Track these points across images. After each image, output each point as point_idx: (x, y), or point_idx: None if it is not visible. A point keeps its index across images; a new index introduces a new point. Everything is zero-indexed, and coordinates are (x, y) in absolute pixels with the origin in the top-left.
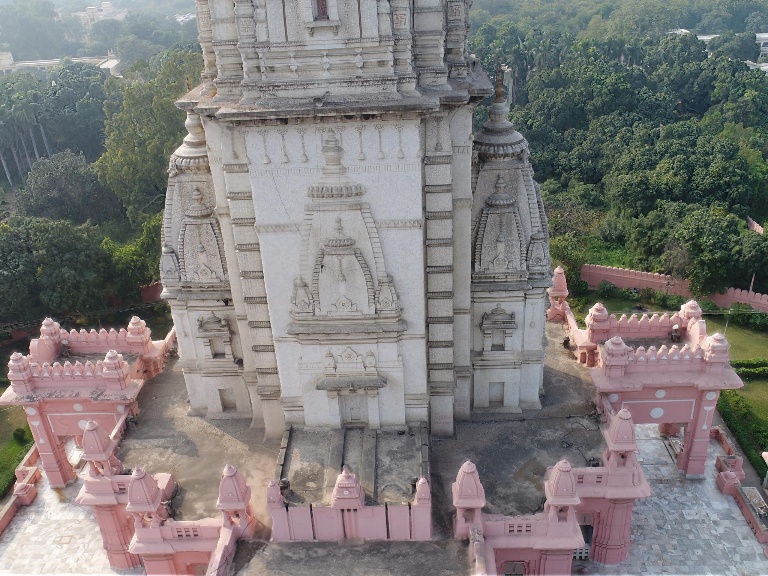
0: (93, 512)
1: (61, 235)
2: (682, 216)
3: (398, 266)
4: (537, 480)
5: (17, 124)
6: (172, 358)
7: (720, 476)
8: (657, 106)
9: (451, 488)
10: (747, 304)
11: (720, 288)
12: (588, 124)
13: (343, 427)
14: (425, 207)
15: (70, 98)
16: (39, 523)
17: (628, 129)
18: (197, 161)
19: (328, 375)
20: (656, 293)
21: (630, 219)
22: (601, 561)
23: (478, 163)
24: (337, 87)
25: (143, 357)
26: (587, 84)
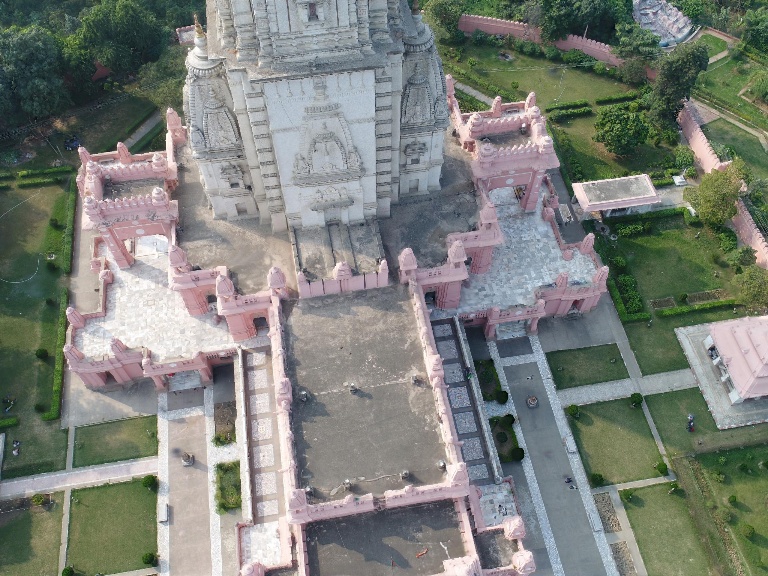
0: (159, 282)
1: (22, 49)
2: None
3: (360, 141)
4: (442, 241)
5: None
6: (180, 171)
7: (544, 211)
8: None
9: (394, 253)
10: (580, 51)
11: (563, 36)
12: None
13: (326, 225)
14: (375, 105)
15: None
16: (127, 294)
17: None
18: (210, 72)
19: (318, 202)
20: (516, 42)
21: None
22: (476, 273)
23: None
24: (323, 54)
25: (167, 180)
26: None
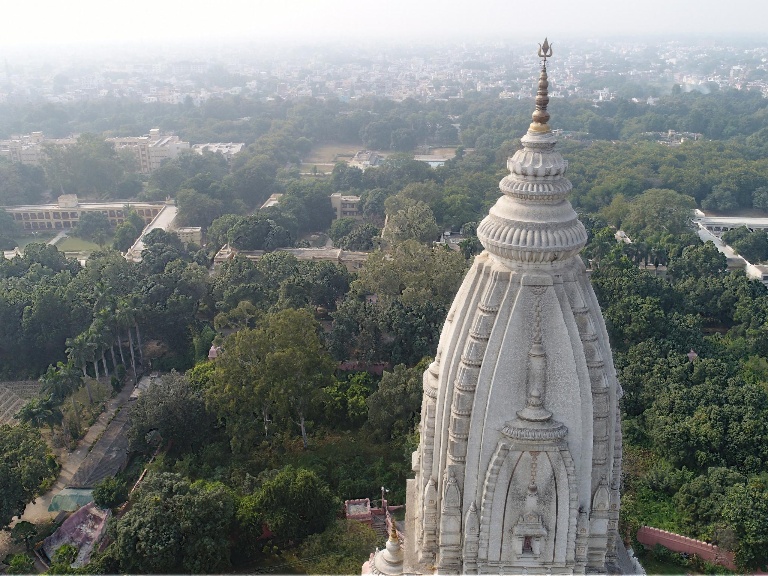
0: None
1: (204, 507)
2: (724, 484)
3: None
4: None
5: (119, 326)
6: None
7: None
8: (688, 333)
9: None
10: None
11: (762, 567)
12: (626, 345)
13: None
14: None
15: (161, 293)
16: None
17: (665, 361)
18: None
19: None
20: (705, 564)
21: (673, 465)
22: None
23: None
24: None
25: None
26: (625, 308)
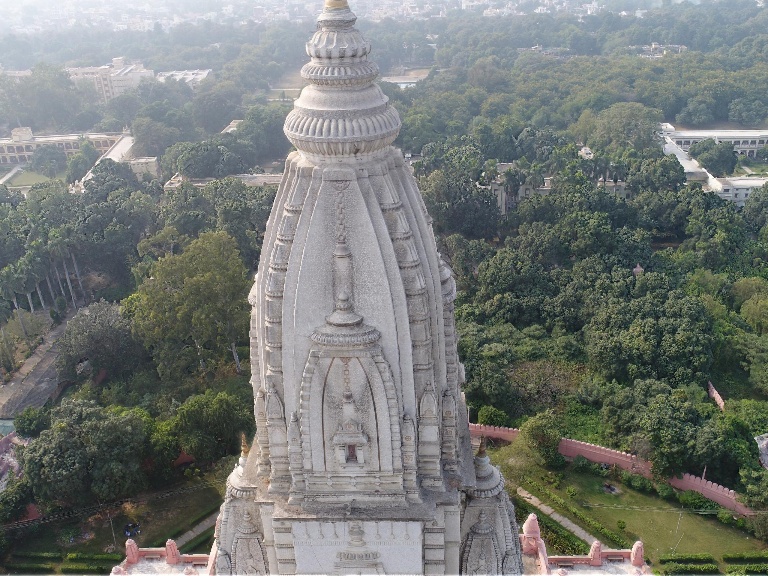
0: None
1: (110, 432)
2: (648, 395)
3: None
4: None
5: (52, 257)
6: None
7: None
8: (635, 247)
9: None
10: (699, 493)
11: (677, 474)
12: (572, 262)
13: None
14: (424, 557)
15: (98, 223)
16: None
17: (607, 276)
18: (248, 494)
19: None
20: (623, 474)
21: (605, 379)
22: None
23: (465, 501)
24: (361, 497)
25: None
26: (572, 224)
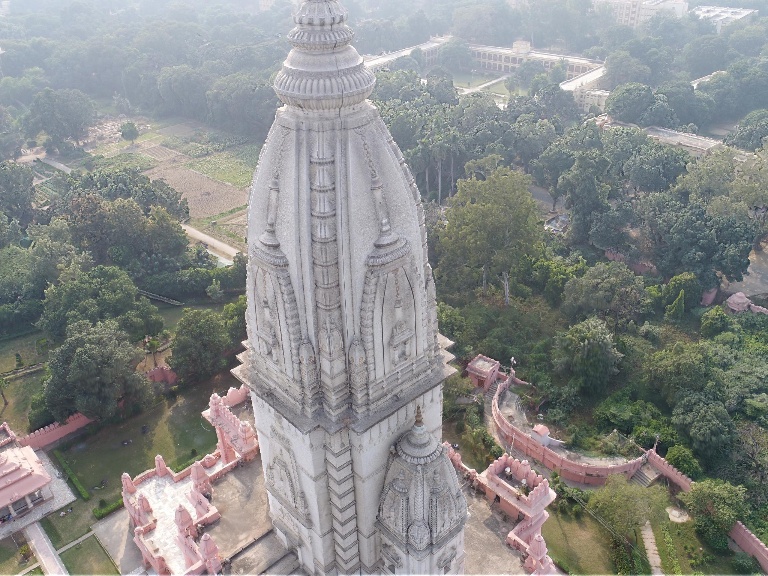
0: None
1: None
2: None
3: None
4: None
5: (433, 156)
6: None
7: None
8: None
9: None
10: None
11: None
12: None
13: (290, 549)
14: None
15: (487, 138)
16: None
17: None
18: None
19: (280, 519)
20: None
21: None
22: None
23: (395, 454)
24: None
25: None
26: None
